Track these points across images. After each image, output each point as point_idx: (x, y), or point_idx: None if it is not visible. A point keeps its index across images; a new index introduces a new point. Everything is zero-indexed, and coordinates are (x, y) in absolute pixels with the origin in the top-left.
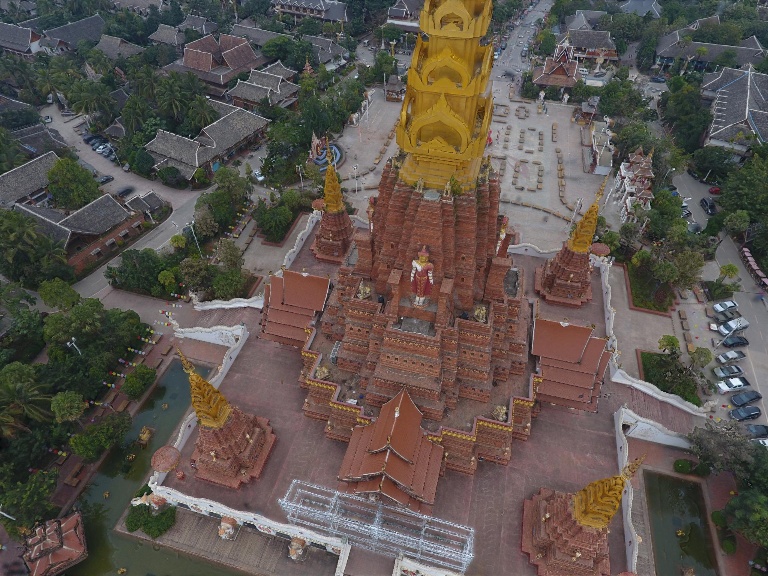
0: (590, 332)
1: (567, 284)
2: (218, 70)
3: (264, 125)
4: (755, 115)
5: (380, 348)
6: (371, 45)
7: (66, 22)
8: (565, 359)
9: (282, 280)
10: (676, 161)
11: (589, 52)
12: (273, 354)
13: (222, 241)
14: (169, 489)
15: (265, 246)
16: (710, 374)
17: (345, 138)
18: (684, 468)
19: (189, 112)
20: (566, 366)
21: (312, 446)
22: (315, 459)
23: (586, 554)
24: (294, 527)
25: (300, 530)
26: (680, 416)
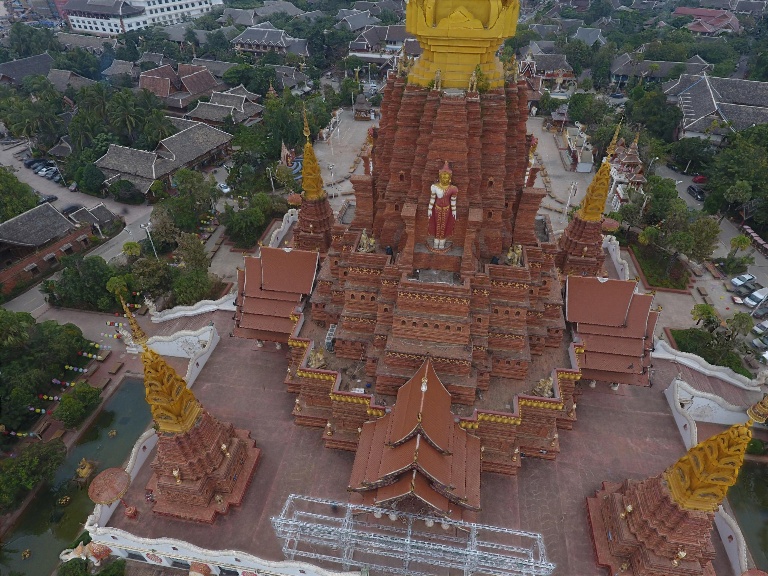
0: (633, 286)
1: (581, 259)
2: (177, 95)
3: (228, 140)
4: (723, 107)
5: (393, 311)
6: (334, 77)
7: (11, 59)
8: (607, 323)
9: (259, 261)
10: (657, 152)
11: (548, 74)
12: (250, 358)
13: (184, 235)
14: (114, 530)
15: (234, 253)
16: (749, 347)
17: (316, 152)
18: (757, 447)
19: (145, 126)
20: (609, 332)
21: (308, 459)
22: (313, 475)
23: (690, 554)
24: (293, 563)
25: (302, 567)
26: (733, 391)
